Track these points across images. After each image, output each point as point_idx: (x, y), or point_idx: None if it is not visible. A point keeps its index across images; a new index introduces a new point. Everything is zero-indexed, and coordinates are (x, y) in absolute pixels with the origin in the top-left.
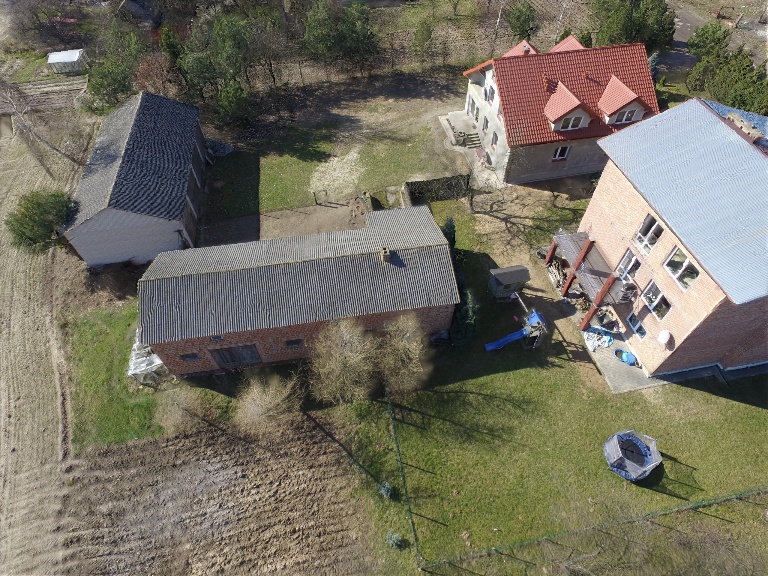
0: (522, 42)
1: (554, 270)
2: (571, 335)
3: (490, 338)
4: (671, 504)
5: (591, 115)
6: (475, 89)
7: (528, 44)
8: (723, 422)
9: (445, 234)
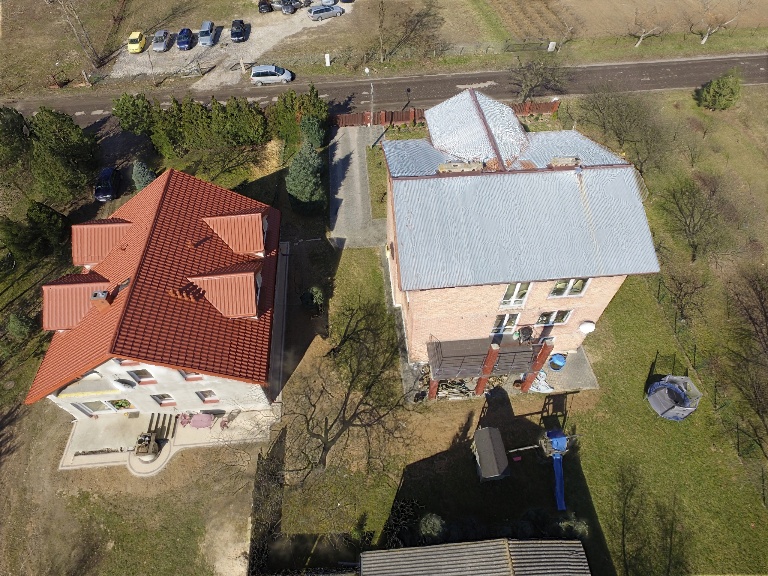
0: (45, 291)
1: (445, 392)
2: (533, 404)
3: (545, 500)
4: (695, 383)
5: (260, 268)
6: (77, 393)
7: (60, 286)
8: (609, 315)
9: (443, 534)
